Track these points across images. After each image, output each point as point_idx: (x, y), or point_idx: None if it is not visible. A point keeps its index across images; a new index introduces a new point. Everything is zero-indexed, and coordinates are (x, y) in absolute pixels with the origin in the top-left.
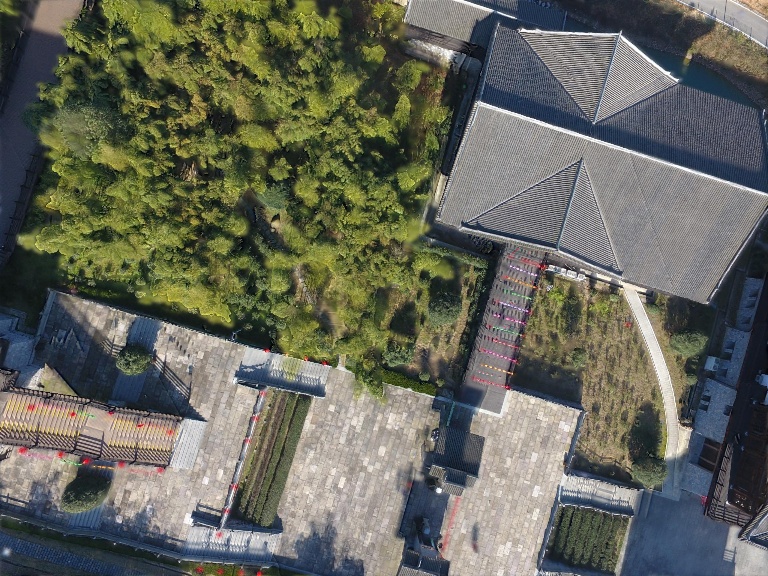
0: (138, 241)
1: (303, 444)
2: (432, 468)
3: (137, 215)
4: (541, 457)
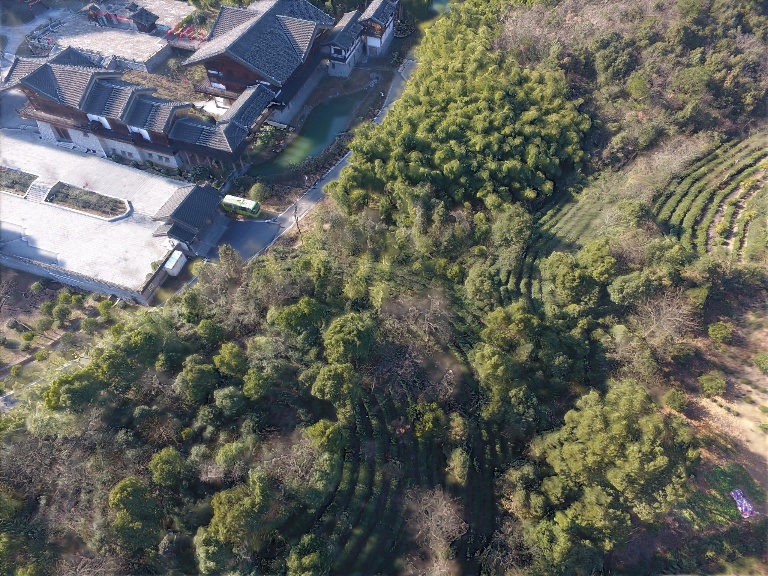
0: None
1: None
2: None
3: None
4: None
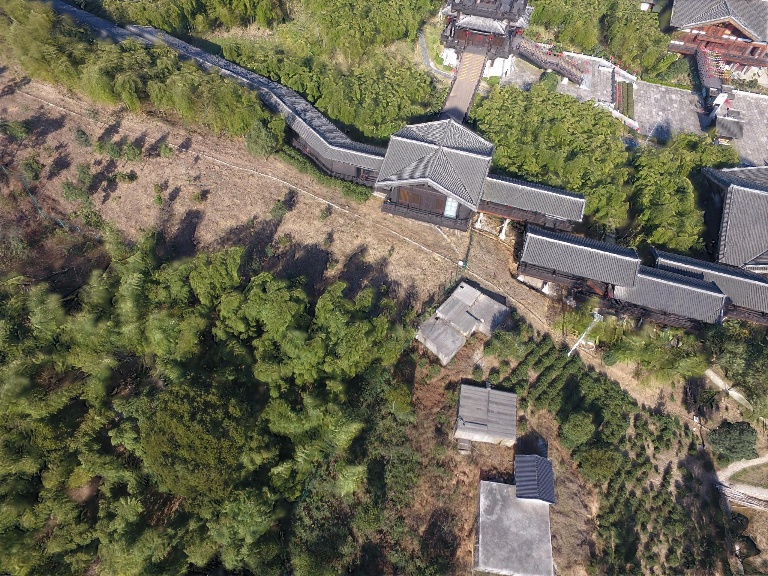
0: (564, 8)
1: (634, 101)
2: (710, 91)
3: (562, 3)
4: (759, 111)
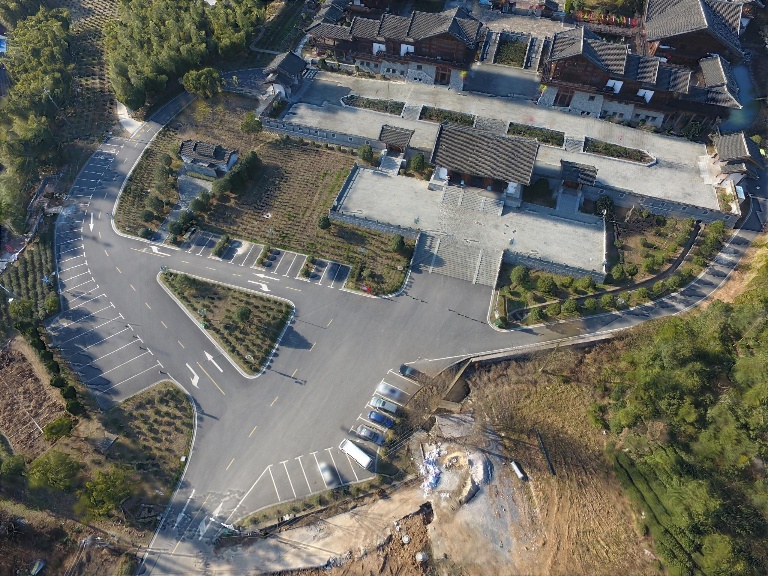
0: None
1: None
2: None
3: None
4: (549, 34)
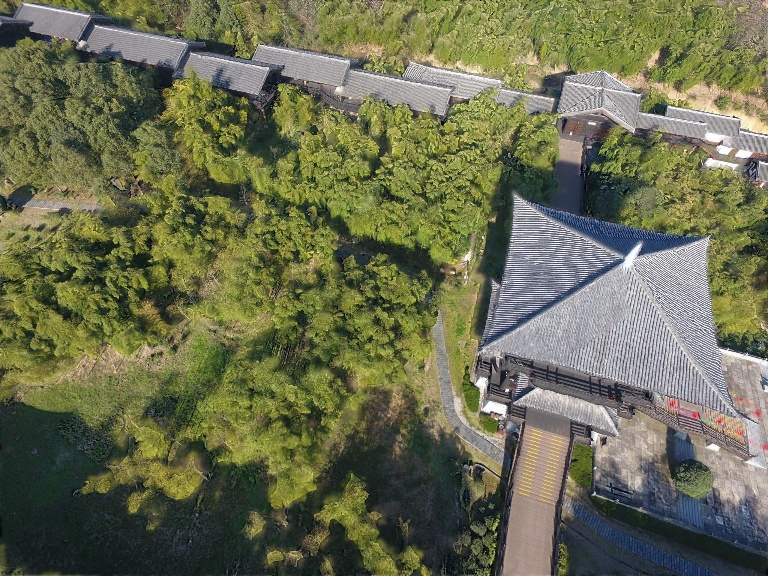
0: None
1: None
2: None
3: None
4: None
